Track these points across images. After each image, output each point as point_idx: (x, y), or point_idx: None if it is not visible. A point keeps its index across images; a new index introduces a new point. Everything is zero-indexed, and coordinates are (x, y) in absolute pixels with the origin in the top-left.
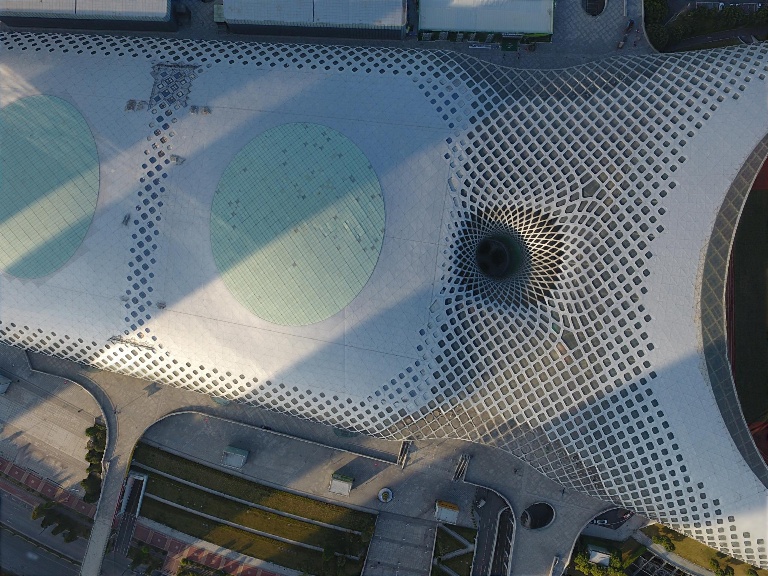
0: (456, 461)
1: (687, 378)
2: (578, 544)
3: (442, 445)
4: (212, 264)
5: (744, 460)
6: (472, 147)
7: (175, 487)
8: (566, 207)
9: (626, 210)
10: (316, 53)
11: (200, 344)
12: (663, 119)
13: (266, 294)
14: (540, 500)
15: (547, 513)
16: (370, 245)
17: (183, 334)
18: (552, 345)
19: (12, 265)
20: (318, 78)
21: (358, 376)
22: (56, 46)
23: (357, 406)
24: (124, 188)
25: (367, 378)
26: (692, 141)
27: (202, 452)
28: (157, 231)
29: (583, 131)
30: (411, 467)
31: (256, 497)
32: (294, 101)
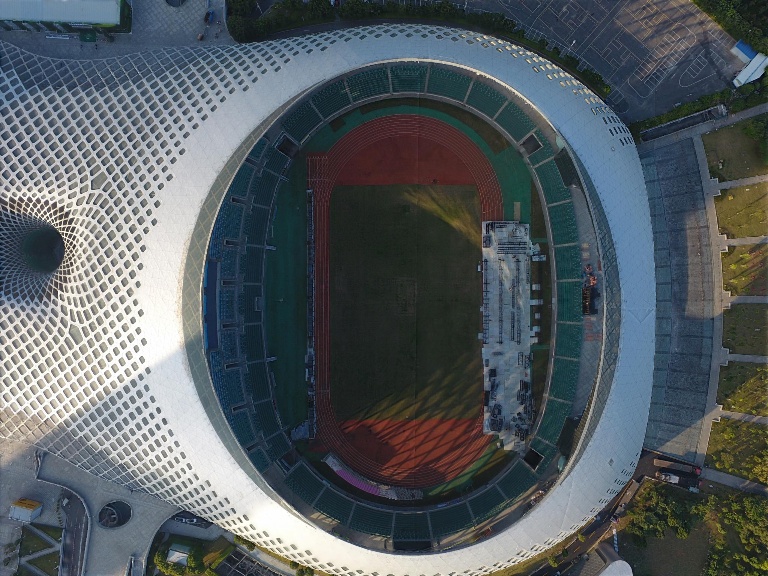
0: (34, 458)
1: (174, 374)
2: (159, 543)
3: (16, 442)
4: None
5: (232, 458)
6: None
7: None
8: (77, 199)
9: (127, 203)
10: None
11: None
12: (176, 111)
13: None
14: (117, 498)
15: None
16: None
17: None
18: (61, 340)
19: None
20: None
21: None
22: None
23: None
24: None
25: None
26: (195, 133)
27: None
28: None
29: (100, 122)
30: None
31: None
32: None
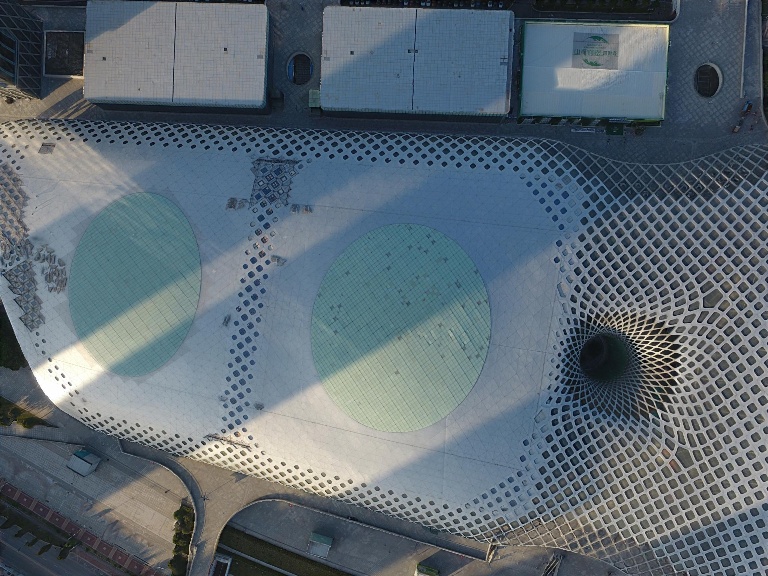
0: (546, 560)
1: None
2: None
3: None
4: (312, 368)
5: None
6: (583, 250)
7: (258, 570)
8: (684, 317)
9: (752, 324)
10: (417, 146)
11: (296, 445)
12: None
13: (367, 400)
14: None
15: None
16: (475, 353)
17: (280, 435)
18: (665, 462)
19: (114, 363)
20: (421, 175)
21: (457, 483)
22: (156, 139)
23: (453, 512)
24: (225, 289)
25: (466, 486)
26: None
27: (286, 537)
28: (257, 332)
29: (704, 235)
30: (498, 562)
31: None
32: (397, 200)
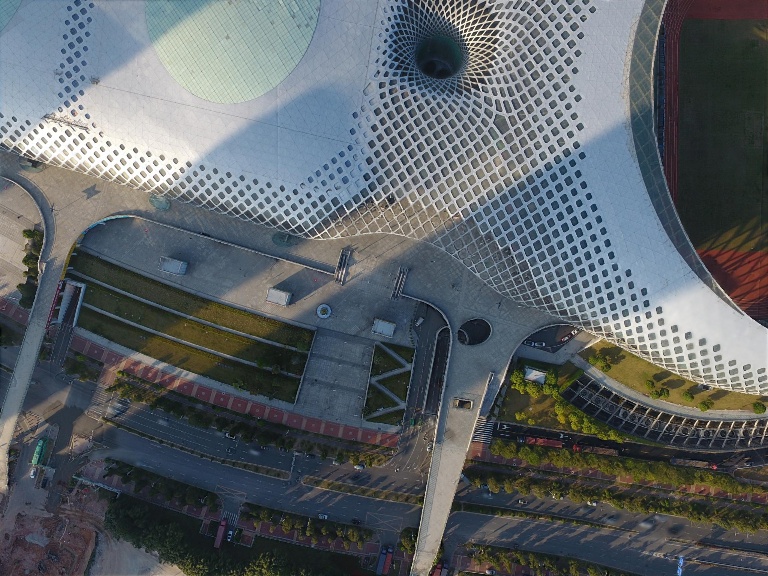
0: (395, 276)
1: (615, 156)
2: (515, 363)
3: (381, 258)
4: (146, 37)
5: (670, 240)
6: None
7: (113, 297)
8: None
9: None
10: None
11: (133, 123)
12: None
13: (199, 68)
14: (477, 316)
15: (485, 334)
16: (304, 22)
17: (116, 112)
18: (484, 130)
19: None
20: None
21: (291, 160)
22: None
23: (290, 194)
24: None
25: (300, 162)
26: None
27: (141, 262)
28: (92, 4)
29: None
30: (350, 283)
31: (194, 310)
32: None
